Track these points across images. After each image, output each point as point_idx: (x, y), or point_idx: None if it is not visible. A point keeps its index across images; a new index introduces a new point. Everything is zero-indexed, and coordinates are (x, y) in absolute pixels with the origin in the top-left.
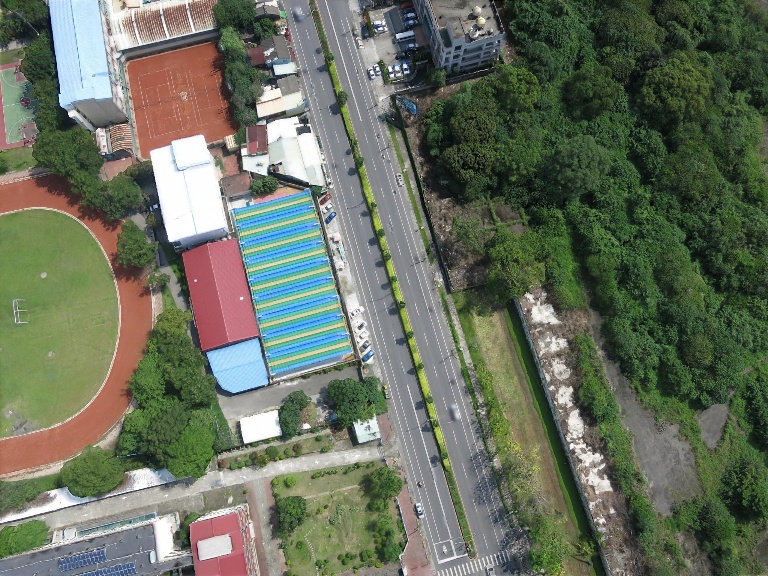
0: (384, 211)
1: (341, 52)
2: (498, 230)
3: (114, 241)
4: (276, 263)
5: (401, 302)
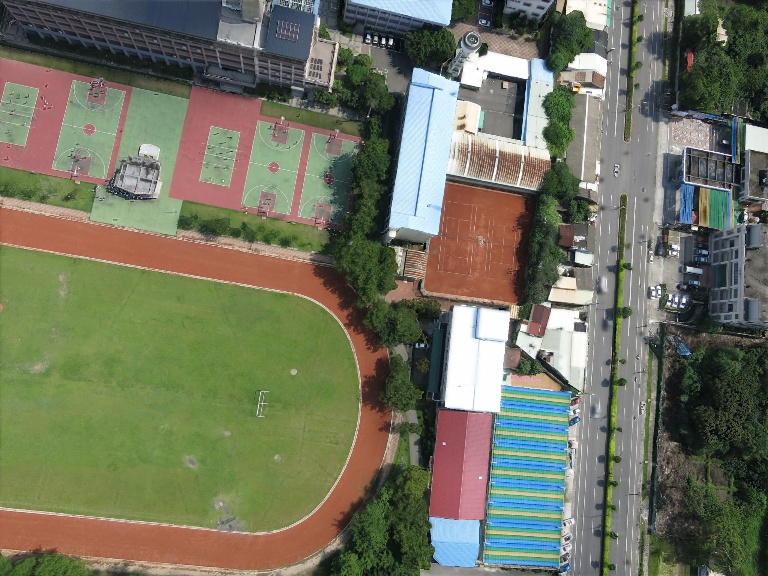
0: (620, 433)
1: (633, 259)
2: (708, 491)
3: (371, 363)
4: (520, 454)
5: (614, 534)
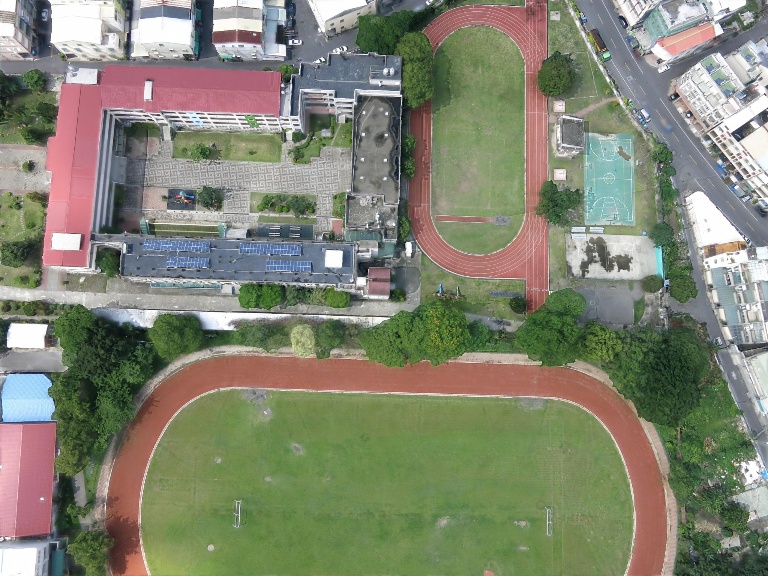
0: None
1: None
2: None
3: (131, 568)
4: None
5: None
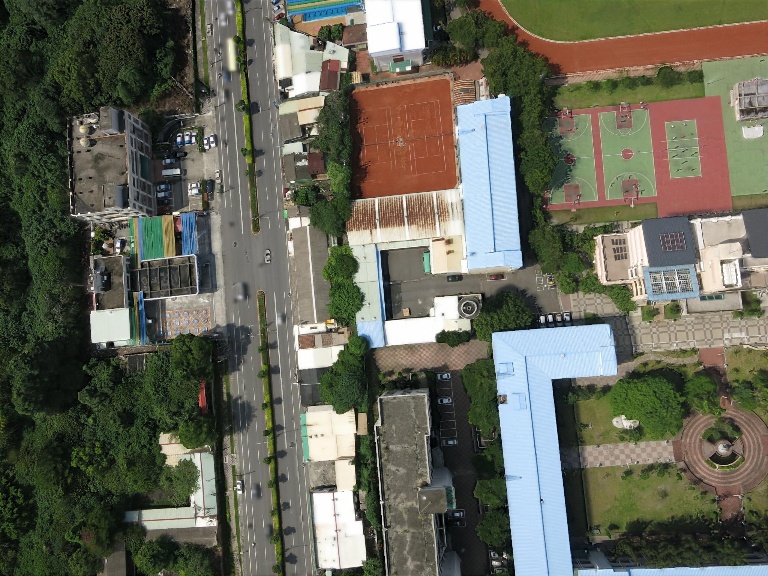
0: (229, 2)
1: (238, 169)
2: None
3: (484, 1)
4: None
5: None
